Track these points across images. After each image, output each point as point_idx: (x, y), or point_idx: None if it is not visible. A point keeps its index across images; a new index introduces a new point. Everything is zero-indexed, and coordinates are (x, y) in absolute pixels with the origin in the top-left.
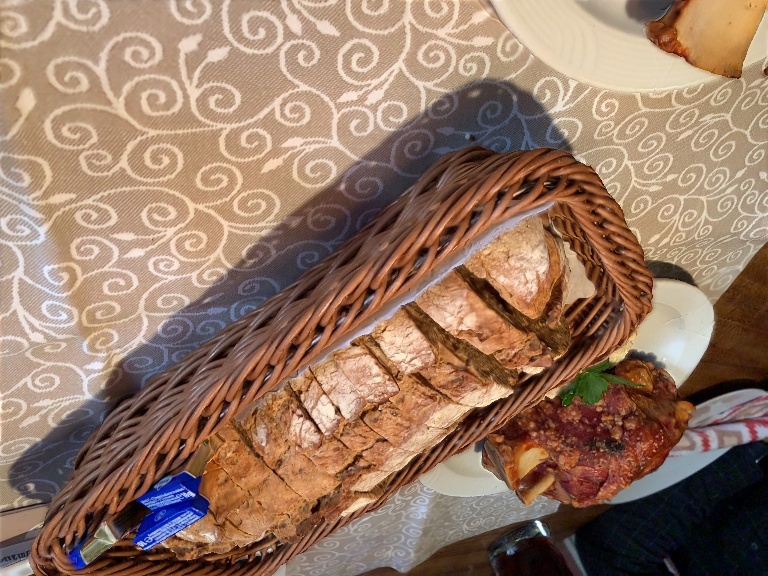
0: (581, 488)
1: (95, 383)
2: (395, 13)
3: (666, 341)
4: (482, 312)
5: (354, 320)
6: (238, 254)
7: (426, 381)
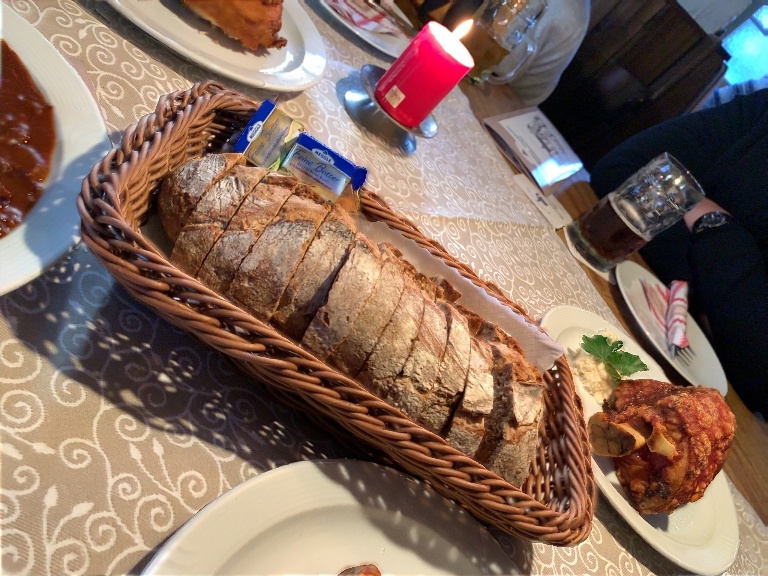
0: None
1: None
2: None
3: None
4: None
5: None
6: None
7: None
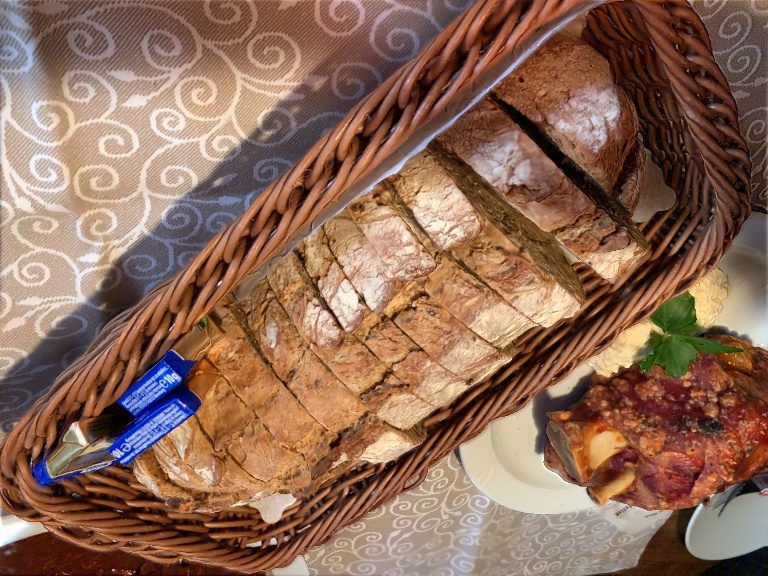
0: (670, 482)
1: (89, 281)
2: None
3: (763, 318)
4: (538, 160)
5: (378, 150)
6: (253, 120)
7: (470, 271)
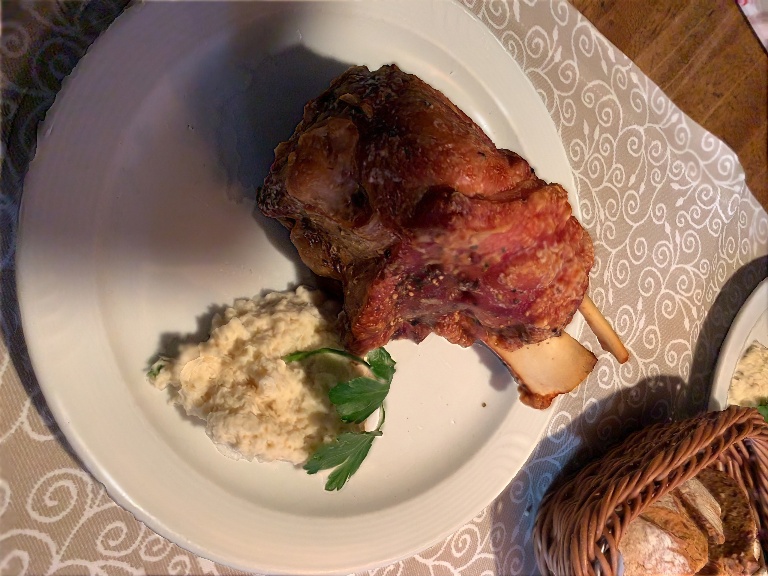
0: None
1: None
2: (423, 572)
3: None
4: None
5: None
6: None
7: None
